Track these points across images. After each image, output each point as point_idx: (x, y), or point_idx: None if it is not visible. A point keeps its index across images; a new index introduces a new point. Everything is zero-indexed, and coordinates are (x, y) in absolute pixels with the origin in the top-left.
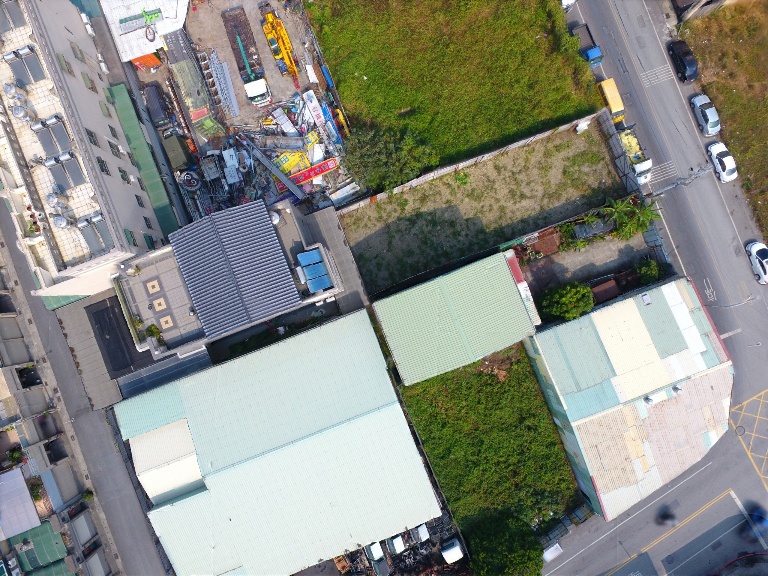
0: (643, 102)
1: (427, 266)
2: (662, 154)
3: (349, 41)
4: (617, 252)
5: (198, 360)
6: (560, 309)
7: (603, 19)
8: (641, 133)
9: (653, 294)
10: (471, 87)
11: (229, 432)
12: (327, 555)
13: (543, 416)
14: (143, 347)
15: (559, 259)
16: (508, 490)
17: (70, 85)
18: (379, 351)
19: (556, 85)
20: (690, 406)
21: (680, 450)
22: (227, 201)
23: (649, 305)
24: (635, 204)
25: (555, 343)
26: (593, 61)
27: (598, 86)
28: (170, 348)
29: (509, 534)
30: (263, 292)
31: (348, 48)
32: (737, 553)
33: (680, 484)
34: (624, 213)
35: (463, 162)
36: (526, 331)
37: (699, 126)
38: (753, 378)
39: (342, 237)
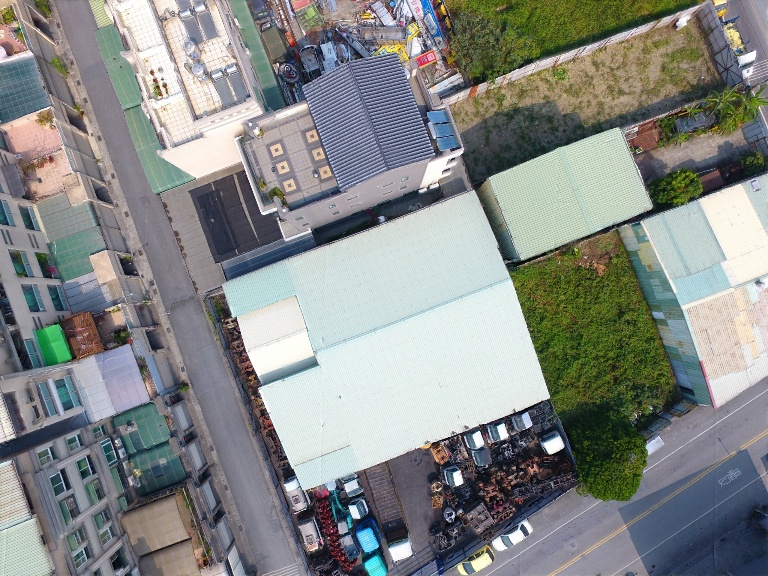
0: None
1: None
2: (762, 51)
3: None
4: (716, 148)
5: (303, 243)
6: (667, 196)
7: None
8: (741, 30)
9: (762, 180)
10: None
11: (339, 309)
12: (434, 437)
13: (642, 311)
14: (266, 209)
15: (658, 155)
16: (607, 384)
17: None
18: (490, 230)
19: None
20: None
21: None
22: None
23: (758, 191)
24: None
25: (663, 228)
26: None
27: None
28: None
29: (612, 424)
30: (399, 141)
31: None
32: None
33: None
34: None
35: (564, 54)
36: (643, 206)
37: None
38: None
39: None
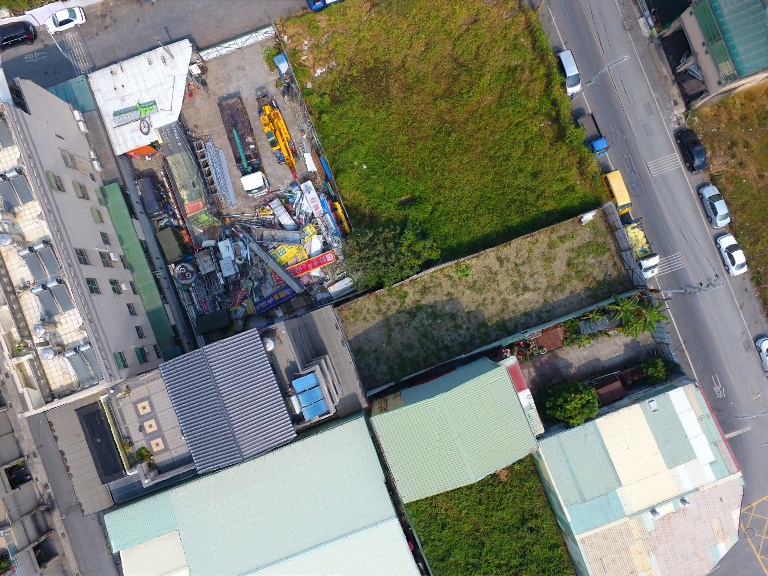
0: (650, 192)
1: (427, 360)
2: (669, 246)
3: (348, 128)
4: (623, 347)
5: None
6: (564, 414)
7: (609, 106)
8: (648, 224)
9: (660, 400)
10: (473, 176)
11: (222, 546)
12: None
13: (546, 517)
14: (133, 471)
15: (563, 354)
16: None
17: (59, 203)
18: (377, 462)
19: (560, 175)
20: (698, 518)
21: (688, 563)
22: (223, 293)
23: (656, 412)
24: (641, 301)
25: (559, 451)
26: (599, 152)
27: (604, 177)
28: (161, 471)
29: None
30: (256, 427)
31: (347, 136)
32: None
33: None
34: (630, 312)
35: None
36: (529, 448)
37: (708, 217)
38: (763, 478)
39: (340, 337)
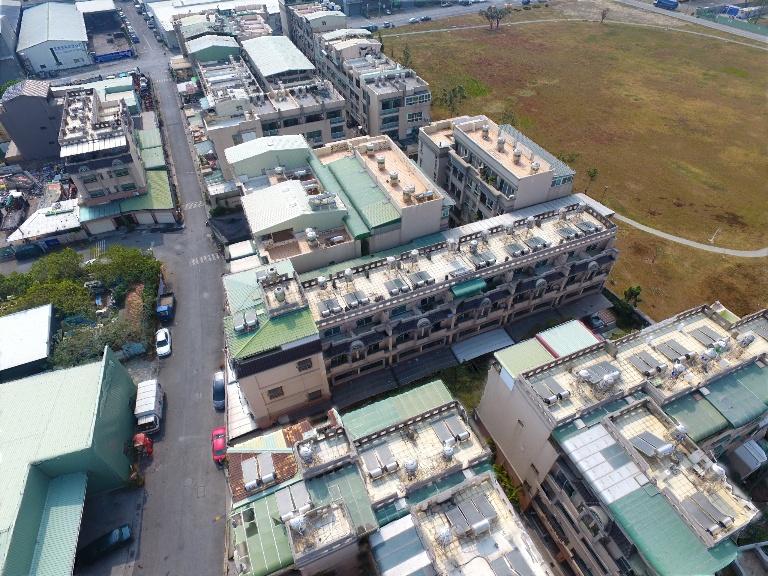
0: None
1: None
2: None
3: None
4: None
5: None
6: None
7: None
8: None
9: None
10: None
11: None
12: None
13: None
14: None
15: None
16: None
17: None
18: None
19: None
20: None
21: None
22: None
23: None
24: None
25: None
26: None
27: None
28: None
29: None
30: None
31: None
32: None
33: None
34: None
35: None
36: None
37: None
38: None
39: None
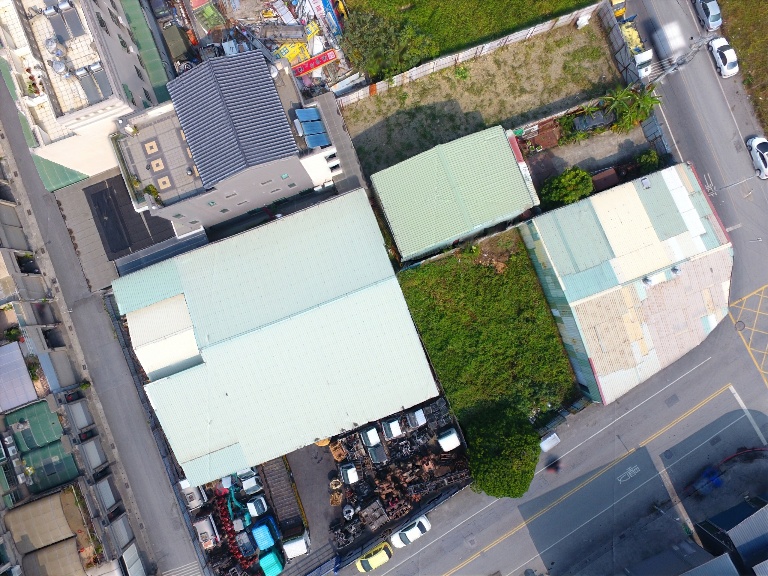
0: None
1: None
2: (663, 50)
3: None
4: (617, 147)
5: (196, 241)
6: (559, 194)
7: None
8: (642, 29)
9: (653, 178)
10: None
11: (226, 307)
12: (323, 434)
13: (541, 309)
14: (141, 207)
15: (559, 153)
16: (506, 381)
17: None
18: (377, 228)
19: None
20: (689, 288)
21: (679, 334)
22: None
23: (649, 189)
24: None
25: (554, 226)
26: None
27: None
28: None
29: (506, 421)
30: (261, 138)
31: None
32: (736, 449)
33: (679, 379)
34: (624, 102)
35: (463, 53)
36: (524, 203)
37: (700, 21)
38: (753, 273)
39: (341, 122)
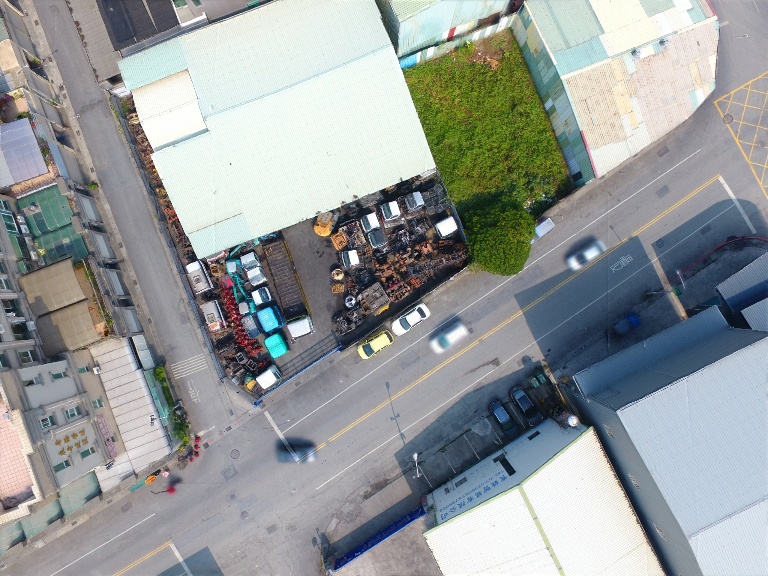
0: None
1: None
2: None
3: None
4: None
5: None
6: None
7: None
8: None
9: None
10: None
11: (229, 80)
12: (324, 207)
13: (535, 104)
14: None
15: None
16: (501, 173)
17: None
18: (373, 3)
19: None
20: (677, 62)
21: (668, 107)
22: None
23: None
24: None
25: (545, 7)
26: None
27: None
28: None
29: (502, 204)
30: None
31: None
32: (726, 238)
33: (669, 170)
34: None
35: None
36: None
37: None
38: (740, 68)
39: None
